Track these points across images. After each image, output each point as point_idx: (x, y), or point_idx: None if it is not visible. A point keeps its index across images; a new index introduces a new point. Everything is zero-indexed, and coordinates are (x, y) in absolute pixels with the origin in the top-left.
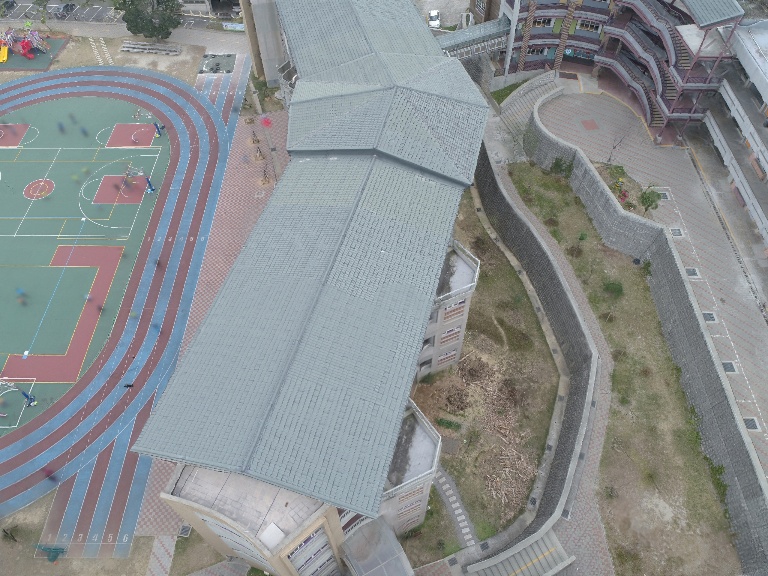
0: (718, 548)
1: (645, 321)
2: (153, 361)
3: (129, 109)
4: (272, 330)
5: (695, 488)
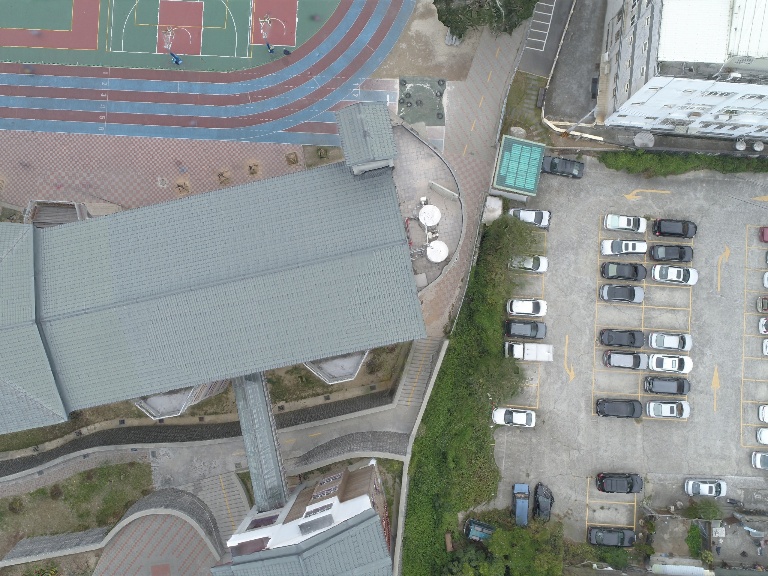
0: None
1: None
2: None
3: (327, 2)
4: None
5: None
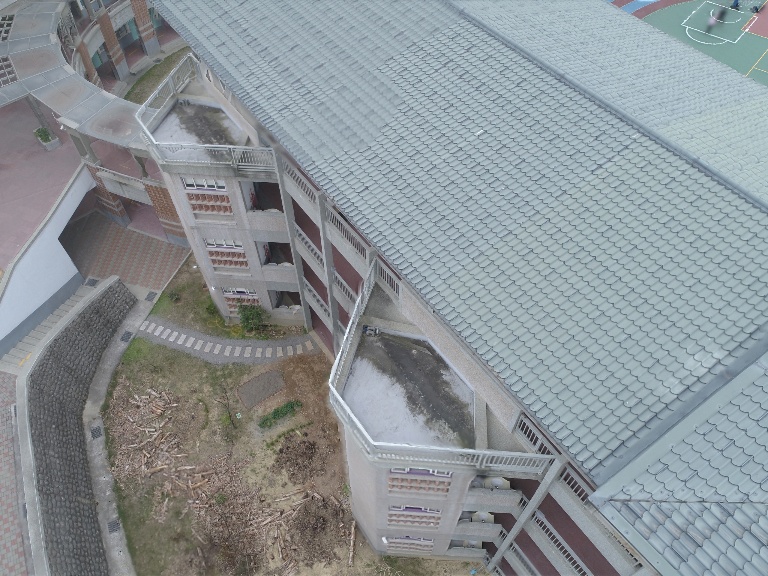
0: None
1: None
2: None
3: None
4: None
5: None
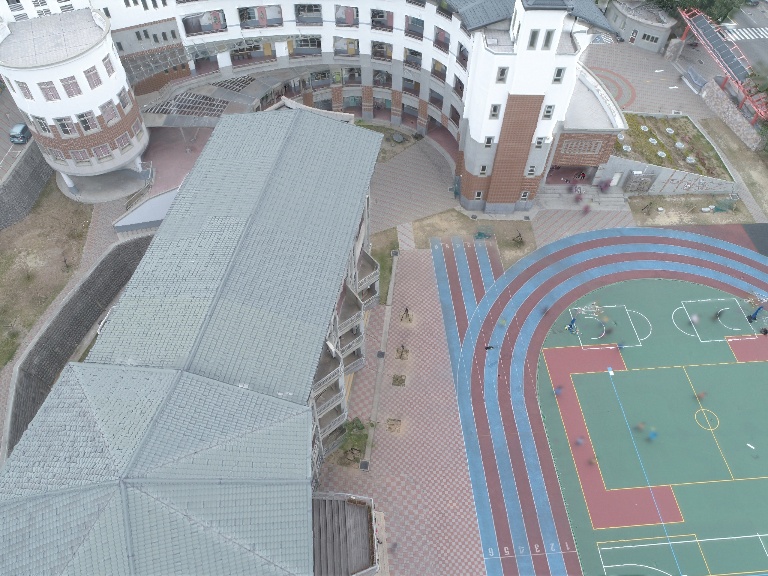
0: (8, 242)
1: None
2: (477, 373)
3: None
4: (294, 188)
5: None
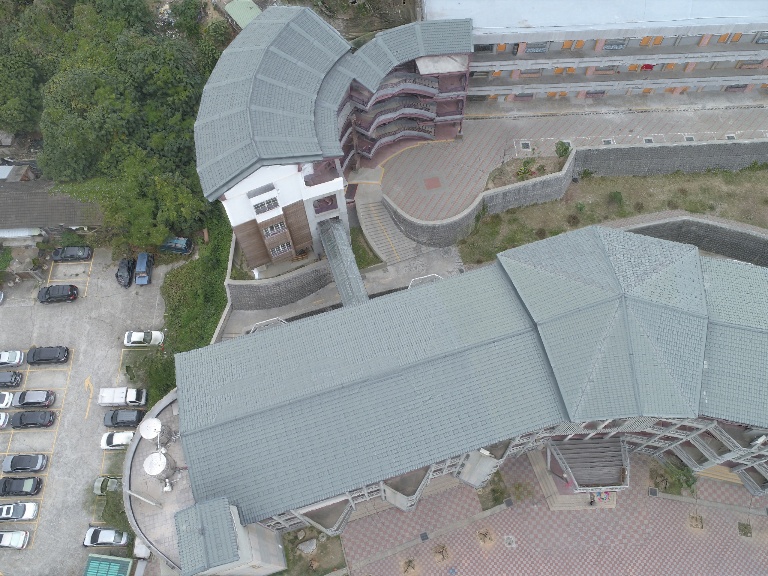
0: None
1: (635, 185)
2: None
3: None
4: None
5: (764, 180)
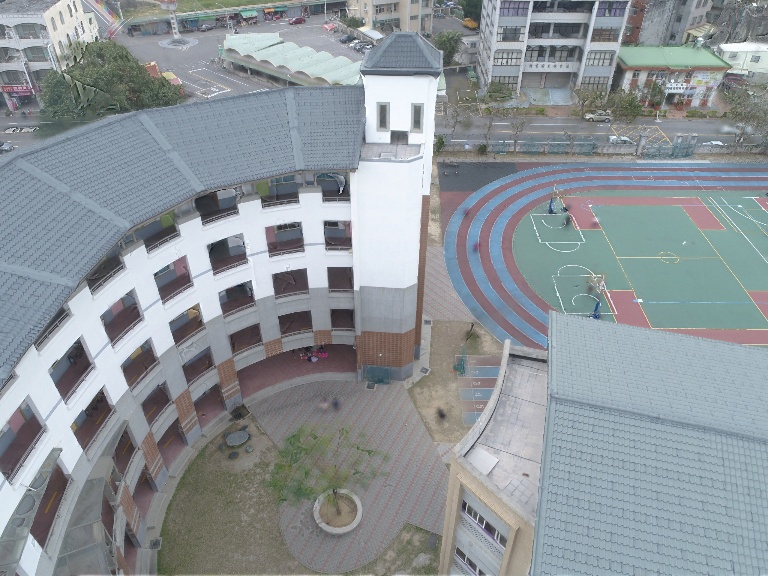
0: None
1: None
2: None
3: None
4: None
5: None
